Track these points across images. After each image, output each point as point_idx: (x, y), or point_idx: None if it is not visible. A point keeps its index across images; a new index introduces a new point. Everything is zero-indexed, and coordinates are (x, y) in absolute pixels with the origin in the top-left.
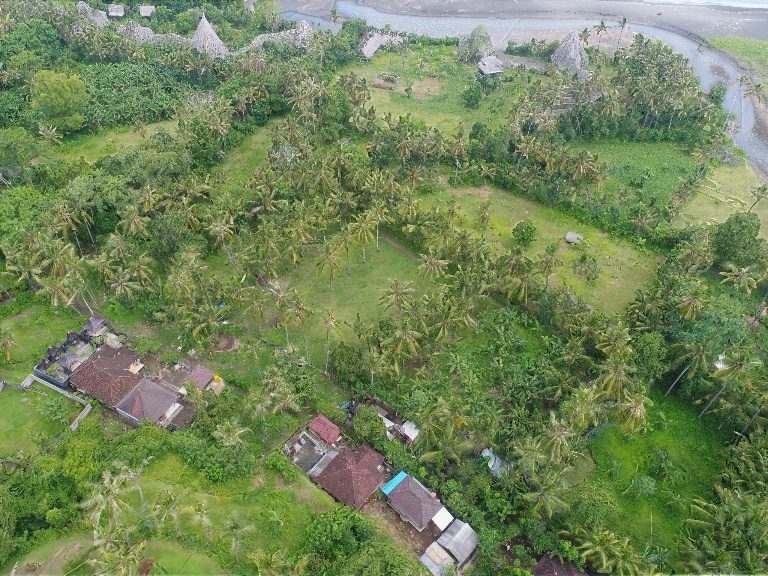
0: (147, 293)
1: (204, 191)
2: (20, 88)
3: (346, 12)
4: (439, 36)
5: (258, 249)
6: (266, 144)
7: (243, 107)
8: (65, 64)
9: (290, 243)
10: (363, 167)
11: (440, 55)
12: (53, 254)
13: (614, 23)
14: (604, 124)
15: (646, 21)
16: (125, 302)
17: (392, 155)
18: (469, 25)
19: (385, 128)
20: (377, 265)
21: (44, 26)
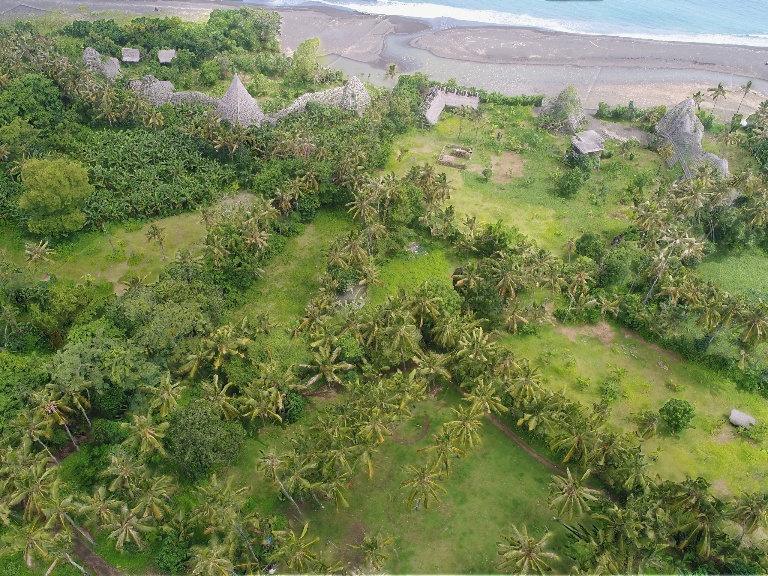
0: (162, 535)
1: (241, 346)
2: (10, 164)
3: (397, 56)
4: (510, 90)
5: (321, 465)
6: (315, 250)
7: (287, 205)
8: (67, 130)
9: (364, 449)
10: (453, 312)
11: (518, 120)
12: (27, 488)
13: (714, 74)
14: (752, 237)
15: (752, 72)
16: (131, 546)
17: (491, 295)
18: (543, 75)
19: (468, 236)
20: (477, 461)
21: (43, 83)
